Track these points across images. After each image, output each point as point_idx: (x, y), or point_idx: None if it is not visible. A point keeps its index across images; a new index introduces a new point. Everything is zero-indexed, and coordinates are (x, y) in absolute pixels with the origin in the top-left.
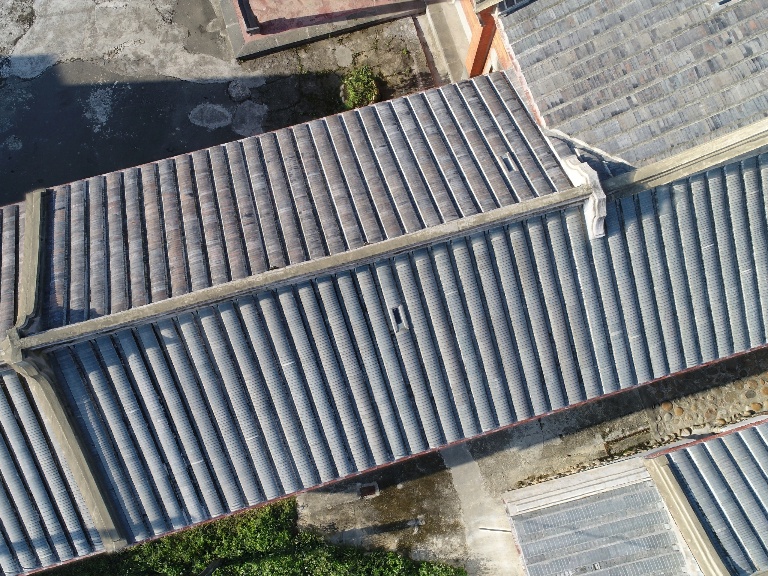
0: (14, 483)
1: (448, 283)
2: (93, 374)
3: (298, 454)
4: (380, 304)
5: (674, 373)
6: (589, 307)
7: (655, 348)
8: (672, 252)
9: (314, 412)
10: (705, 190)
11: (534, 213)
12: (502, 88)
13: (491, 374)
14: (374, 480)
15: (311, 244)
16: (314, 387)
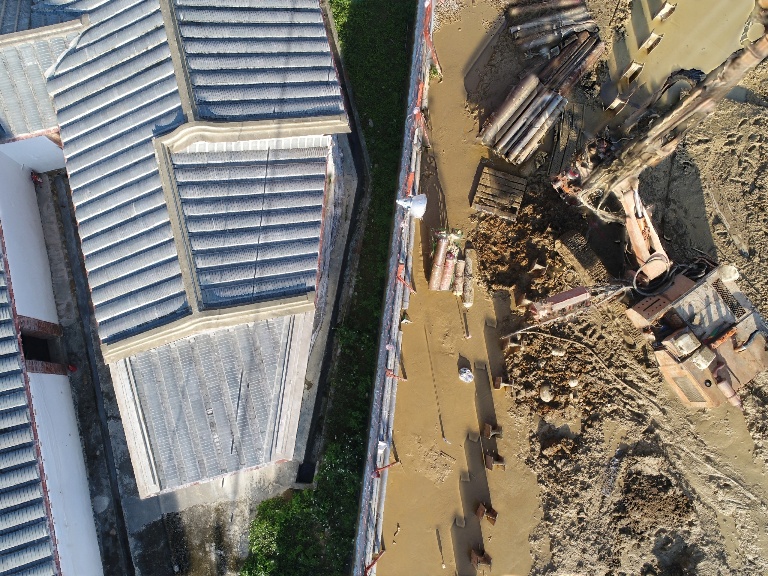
0: None
1: None
2: None
3: None
4: None
5: (16, 331)
6: None
7: None
8: None
9: None
10: None
11: None
12: None
13: None
14: None
15: None
16: None
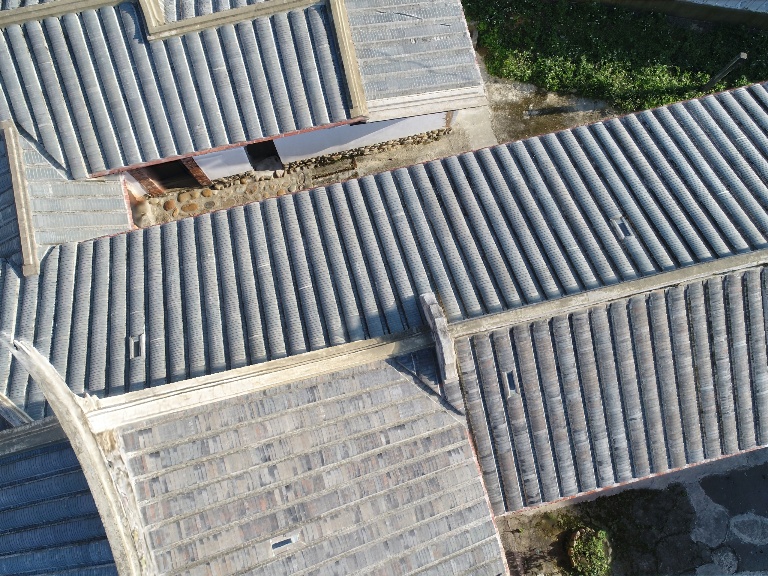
0: None
1: (579, 256)
2: None
3: (695, 126)
4: (644, 240)
5: None
6: (429, 236)
7: (359, 202)
8: (345, 282)
9: (687, 158)
10: (310, 339)
11: None
12: (496, 490)
13: (522, 183)
14: None
15: (720, 298)
16: (693, 175)
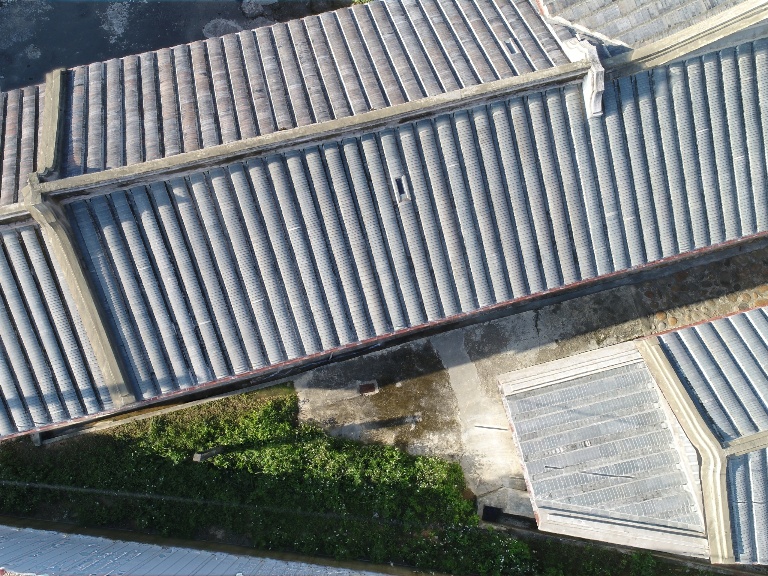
0: (29, 338)
1: (450, 155)
2: (107, 228)
3: (301, 320)
4: (384, 174)
5: (667, 258)
6: (586, 186)
7: (649, 231)
8: (667, 135)
9: (318, 279)
10: (701, 74)
11: (534, 88)
12: None
13: (489, 249)
14: (374, 378)
15: (319, 114)
16: (318, 253)
